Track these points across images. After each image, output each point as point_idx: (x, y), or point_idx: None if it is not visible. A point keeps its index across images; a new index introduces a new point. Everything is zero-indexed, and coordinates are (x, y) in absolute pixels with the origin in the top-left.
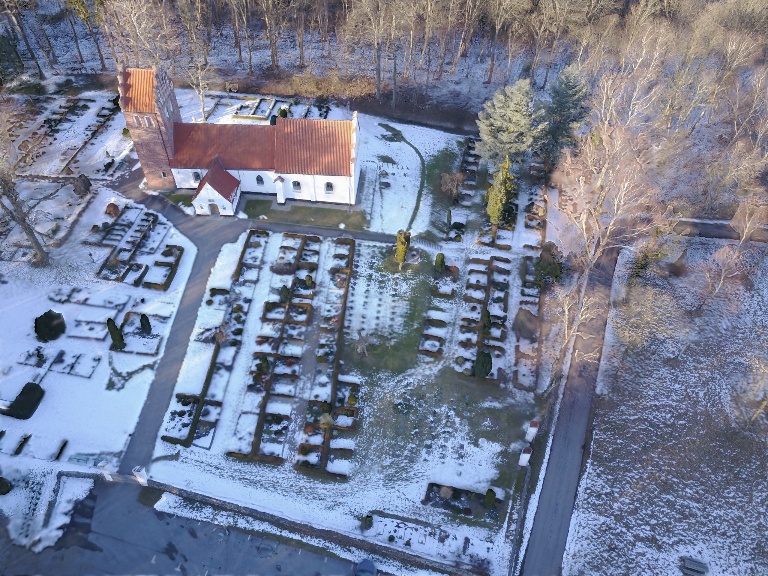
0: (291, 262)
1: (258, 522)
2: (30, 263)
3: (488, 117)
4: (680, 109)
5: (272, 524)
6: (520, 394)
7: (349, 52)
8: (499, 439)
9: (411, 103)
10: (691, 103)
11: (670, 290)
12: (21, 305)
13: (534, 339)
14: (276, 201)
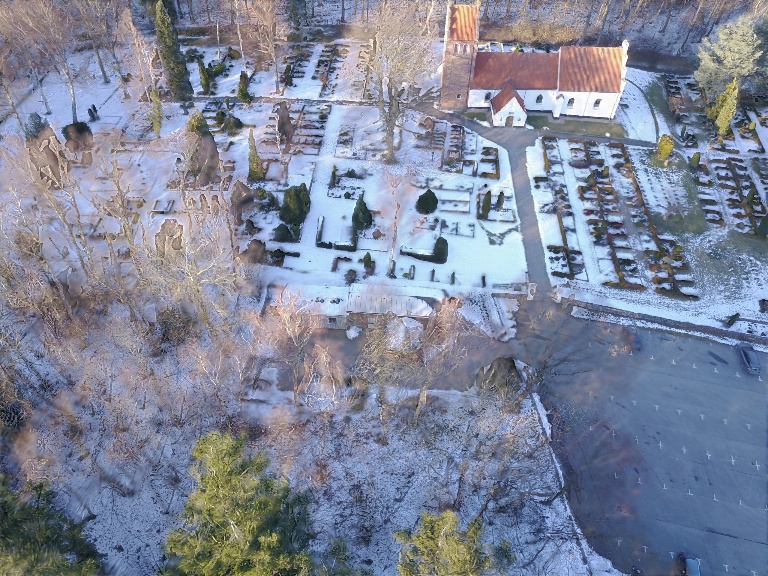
0: (585, 159)
1: (650, 323)
2: (382, 161)
3: (706, 50)
4: None
5: (661, 324)
6: None
7: (534, 8)
8: None
9: None
10: None
11: None
12: (392, 190)
13: None
14: (551, 116)
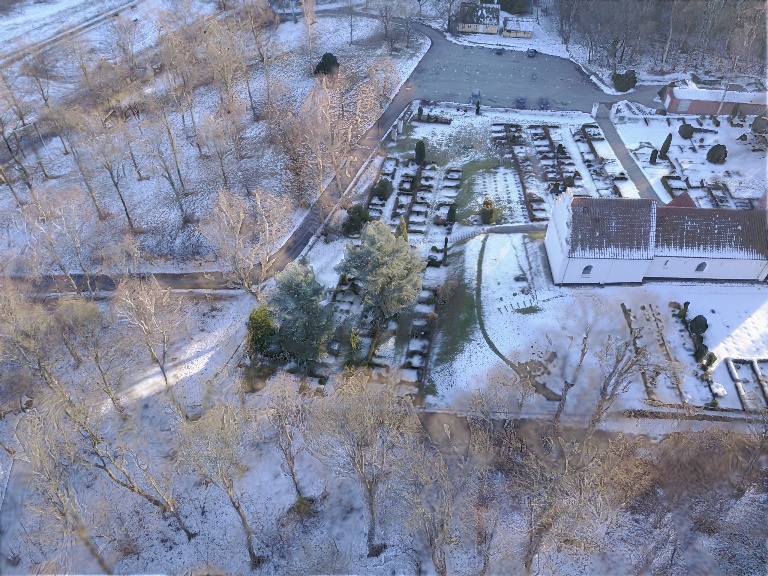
0: None
1: None
2: None
3: None
4: None
5: None
6: (396, 156)
7: None
8: None
9: None
10: None
11: None
12: (756, 169)
13: None
14: None
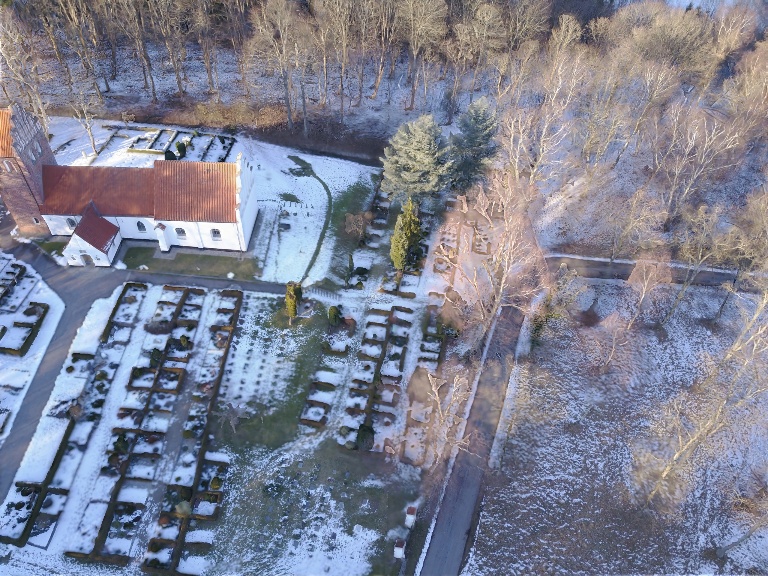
0: (168, 320)
1: None
2: None
3: (394, 153)
4: (598, 143)
5: None
6: (406, 469)
7: (267, 76)
8: (376, 525)
9: (325, 133)
10: (607, 138)
11: (579, 342)
12: None
13: (428, 403)
14: (160, 248)
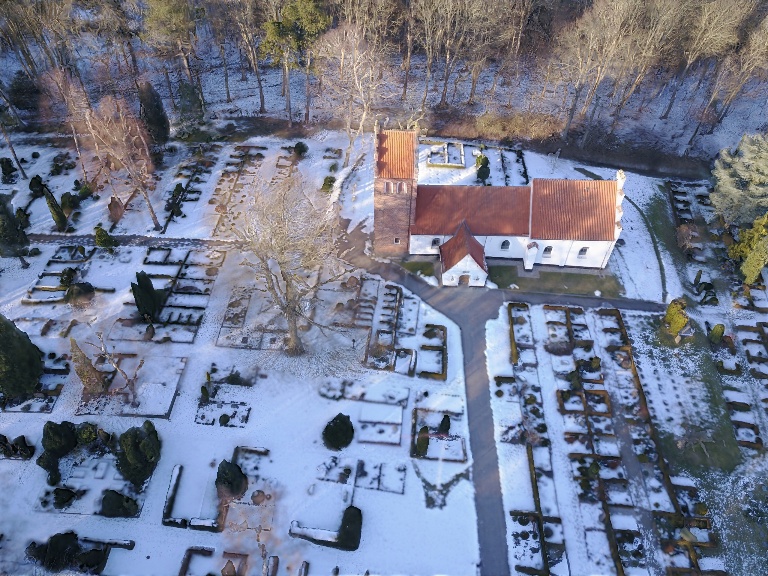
0: (567, 340)
1: None
2: (283, 351)
3: (726, 166)
4: None
5: None
6: None
7: (506, 85)
8: None
9: (598, 143)
10: None
11: None
12: (292, 404)
13: None
14: (521, 267)
